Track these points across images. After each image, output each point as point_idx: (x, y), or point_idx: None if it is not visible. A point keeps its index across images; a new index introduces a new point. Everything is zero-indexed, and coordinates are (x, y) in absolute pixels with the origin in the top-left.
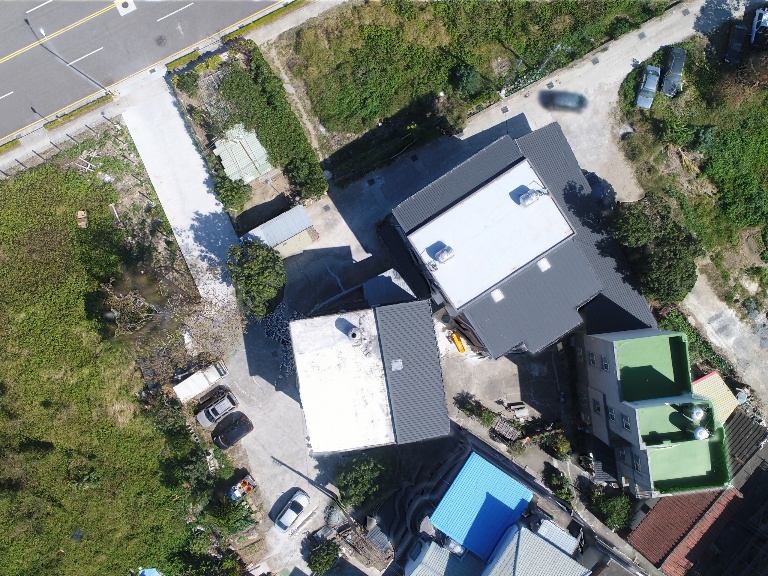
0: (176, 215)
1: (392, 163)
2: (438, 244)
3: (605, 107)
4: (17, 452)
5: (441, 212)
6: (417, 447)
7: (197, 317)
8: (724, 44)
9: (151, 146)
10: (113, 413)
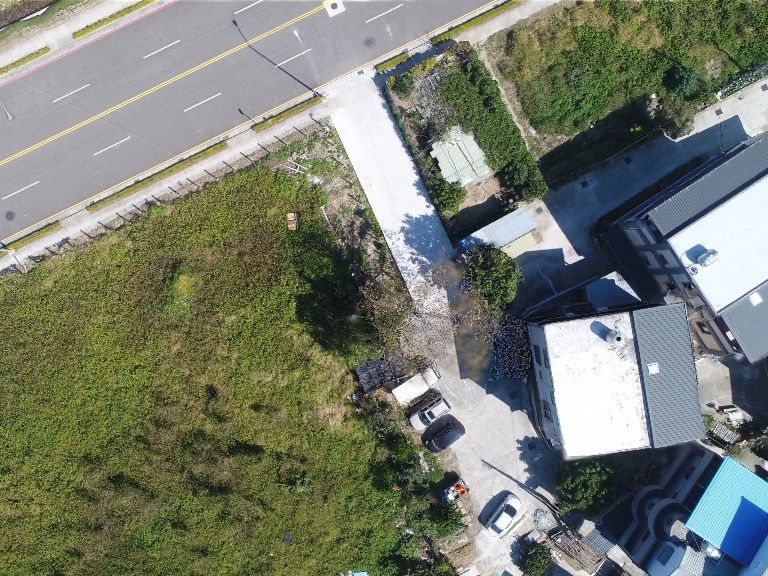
0: (386, 217)
1: (606, 165)
2: (698, 247)
3: None
4: (227, 455)
5: (701, 215)
6: (672, 451)
7: None
8: None
9: (360, 148)
10: (323, 416)
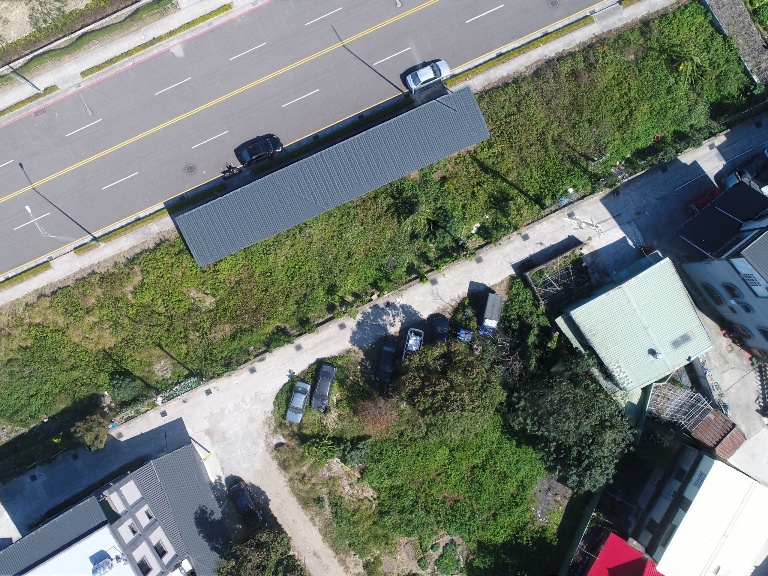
0: None
1: (53, 461)
2: None
3: (261, 416)
4: None
5: (24, 572)
6: None
7: None
8: None
9: None
10: None
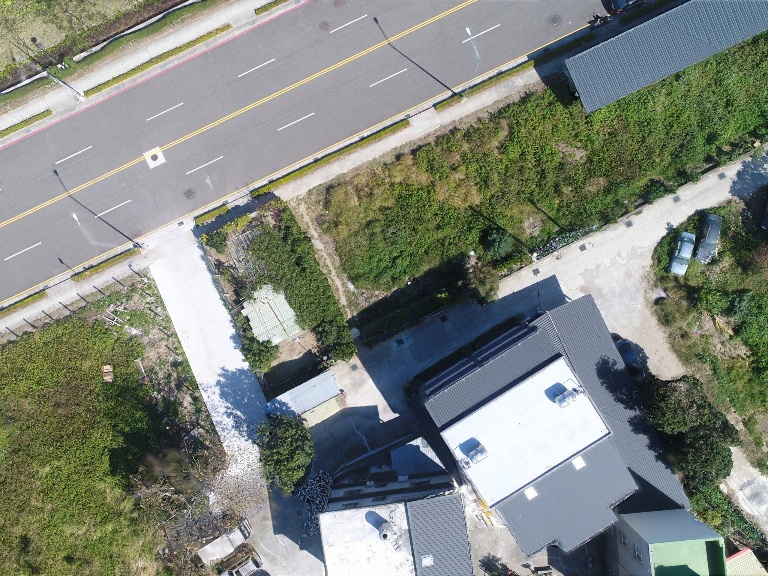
0: (202, 370)
1: (421, 323)
2: (471, 441)
3: (638, 271)
4: None
5: (475, 408)
6: None
7: (222, 476)
8: (761, 209)
9: (178, 300)
10: (136, 569)
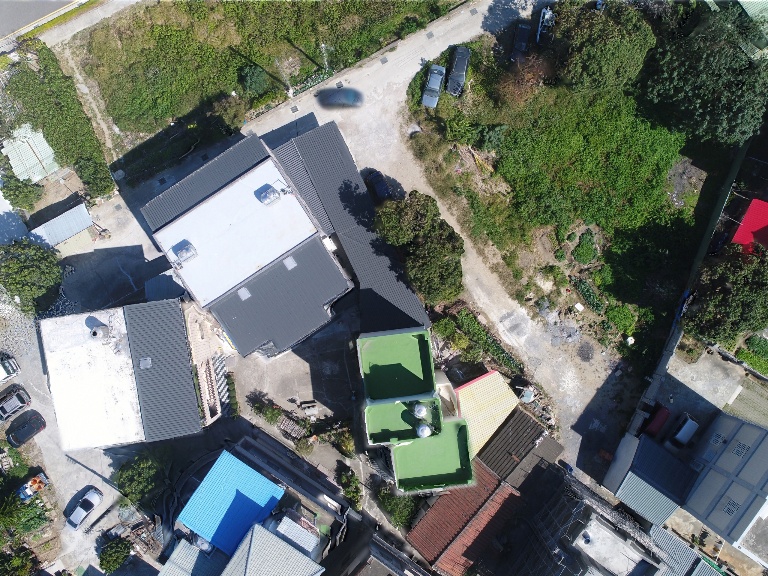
0: None
1: (182, 162)
2: (183, 243)
3: (394, 106)
4: None
5: (186, 211)
6: (168, 445)
7: None
8: (511, 43)
9: None
10: None
